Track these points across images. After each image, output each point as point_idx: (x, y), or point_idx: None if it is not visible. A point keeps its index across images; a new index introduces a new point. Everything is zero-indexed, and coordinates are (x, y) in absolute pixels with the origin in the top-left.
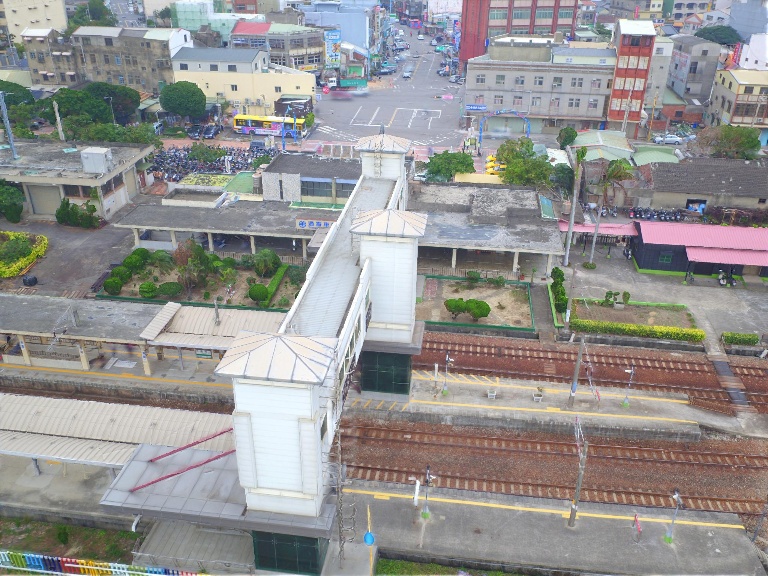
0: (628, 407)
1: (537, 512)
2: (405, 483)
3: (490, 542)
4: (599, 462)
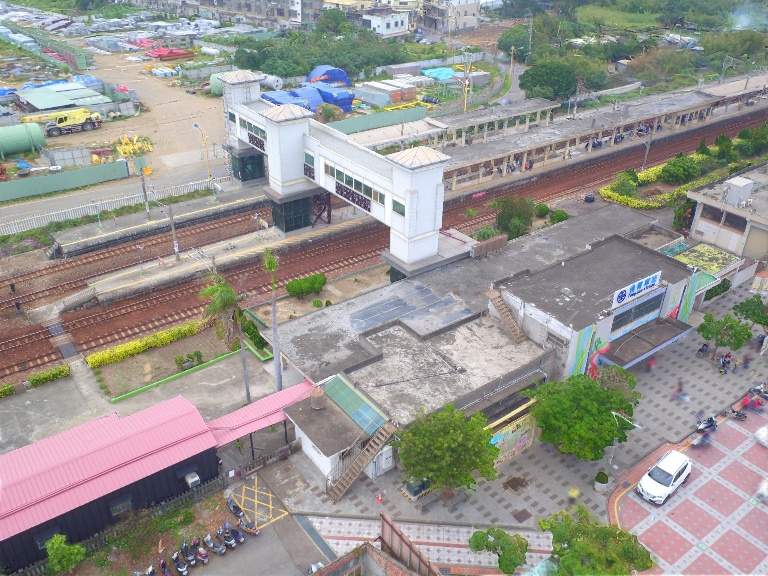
0: (140, 274)
1: (167, 218)
2: (240, 216)
3: (181, 205)
4: (149, 257)
